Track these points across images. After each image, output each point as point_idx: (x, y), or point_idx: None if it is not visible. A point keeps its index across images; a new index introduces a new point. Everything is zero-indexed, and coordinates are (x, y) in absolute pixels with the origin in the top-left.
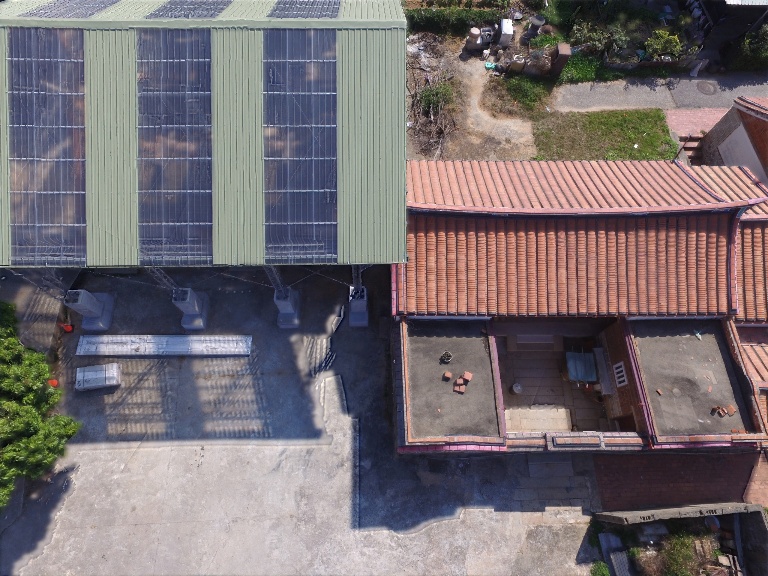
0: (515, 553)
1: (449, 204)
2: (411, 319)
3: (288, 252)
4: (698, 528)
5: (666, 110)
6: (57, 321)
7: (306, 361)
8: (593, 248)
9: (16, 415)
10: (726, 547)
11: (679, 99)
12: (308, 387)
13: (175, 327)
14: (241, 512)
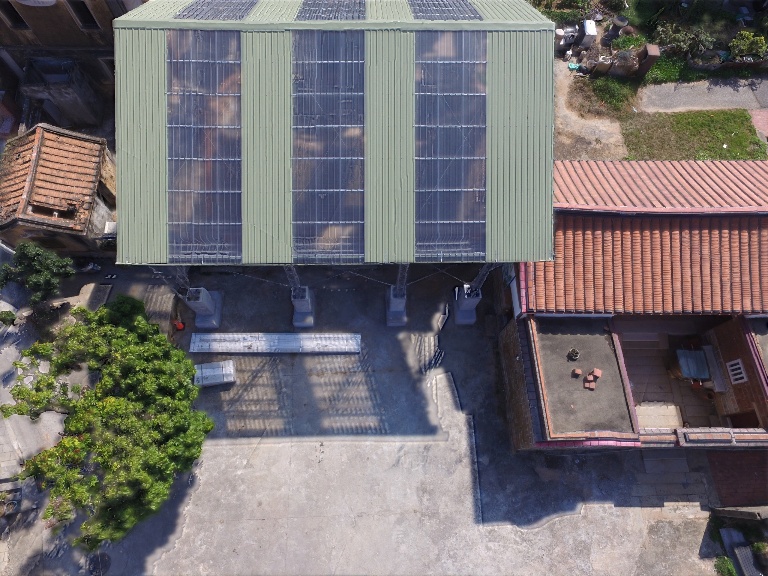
0: (638, 548)
1: (573, 203)
2: (536, 317)
3: (433, 250)
4: None
5: (751, 110)
6: (170, 319)
7: (416, 358)
8: (717, 247)
9: (177, 410)
10: None
11: (763, 99)
12: (420, 384)
13: (284, 325)
14: (365, 507)
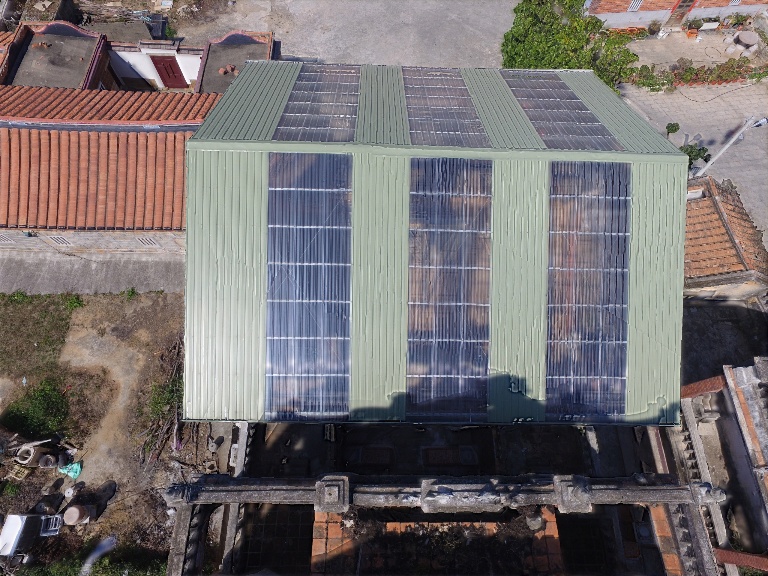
0: None
1: None
2: None
3: None
4: None
5: None
6: None
7: None
8: None
9: None
10: None
11: None
12: None
13: None
14: None
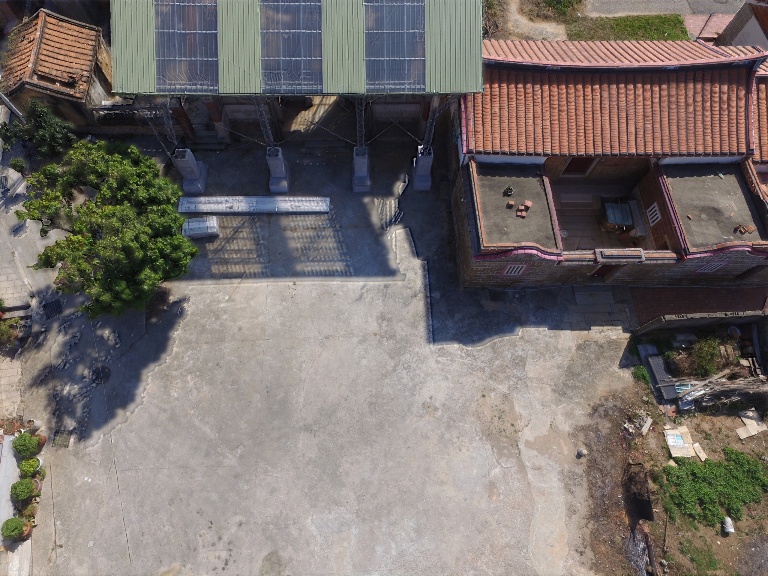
0: (567, 361)
1: None
2: (477, 162)
3: None
4: (722, 335)
5: (684, 15)
6: None
7: (378, 217)
8: (632, 99)
9: (165, 213)
10: (746, 353)
11: (695, 7)
12: (381, 237)
13: (262, 191)
14: (332, 331)
